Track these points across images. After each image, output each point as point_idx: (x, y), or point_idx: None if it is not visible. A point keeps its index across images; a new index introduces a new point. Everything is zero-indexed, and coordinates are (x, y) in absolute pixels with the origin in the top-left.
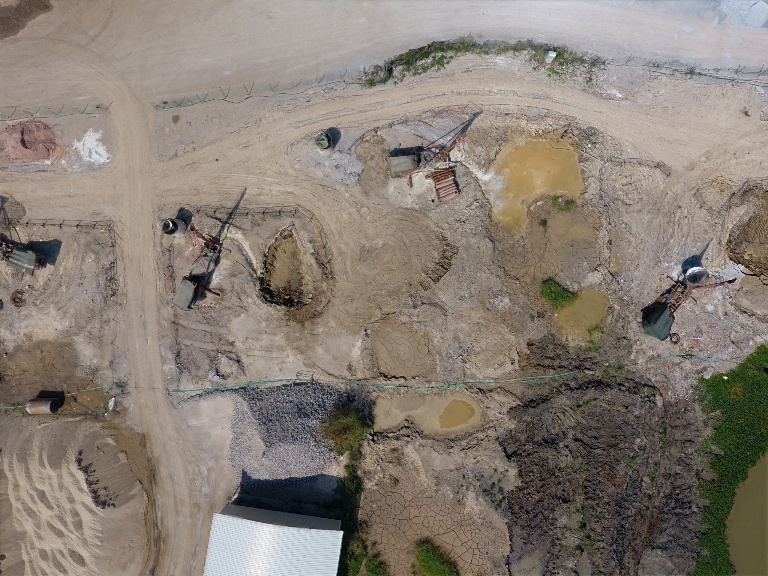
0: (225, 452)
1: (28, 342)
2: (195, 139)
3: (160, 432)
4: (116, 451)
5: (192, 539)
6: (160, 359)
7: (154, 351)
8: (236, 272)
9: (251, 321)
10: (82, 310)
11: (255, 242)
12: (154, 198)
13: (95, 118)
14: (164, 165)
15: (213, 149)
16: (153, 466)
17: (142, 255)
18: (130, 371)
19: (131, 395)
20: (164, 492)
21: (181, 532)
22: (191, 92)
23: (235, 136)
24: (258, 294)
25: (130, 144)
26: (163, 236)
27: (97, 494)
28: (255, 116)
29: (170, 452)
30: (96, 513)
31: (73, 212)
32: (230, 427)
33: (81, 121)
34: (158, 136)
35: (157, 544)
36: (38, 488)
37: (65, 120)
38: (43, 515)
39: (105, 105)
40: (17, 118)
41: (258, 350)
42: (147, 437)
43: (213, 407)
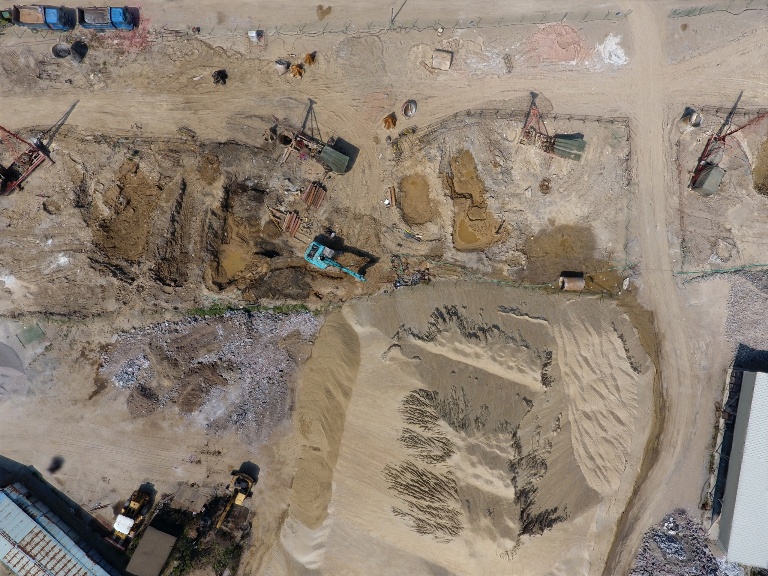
0: (721, 329)
1: (551, 226)
2: (700, 46)
3: (666, 310)
4: (631, 326)
5: (693, 408)
6: (667, 244)
7: (662, 236)
8: (734, 166)
9: (745, 211)
10: (602, 198)
11: (752, 139)
12: (664, 98)
13: (615, 24)
14: (673, 68)
15: (715, 55)
16: (660, 341)
17: (653, 149)
18: (641, 254)
19: (642, 276)
20: (669, 365)
21: (683, 401)
22: (697, 3)
23: (734, 44)
24: (753, 186)
25: (645, 48)
26: (671, 132)
27: (631, 361)
28: (751, 27)
29: (675, 328)
30: (633, 378)
31: (594, 109)
32: (726, 306)
33: (603, 26)
34: (669, 42)
35: (662, 412)
36: (582, 355)
37: (589, 25)
38: (585, 380)
39: (623, 13)
40: (547, 22)
41: (751, 237)
42: (655, 314)
43: (711, 288)
